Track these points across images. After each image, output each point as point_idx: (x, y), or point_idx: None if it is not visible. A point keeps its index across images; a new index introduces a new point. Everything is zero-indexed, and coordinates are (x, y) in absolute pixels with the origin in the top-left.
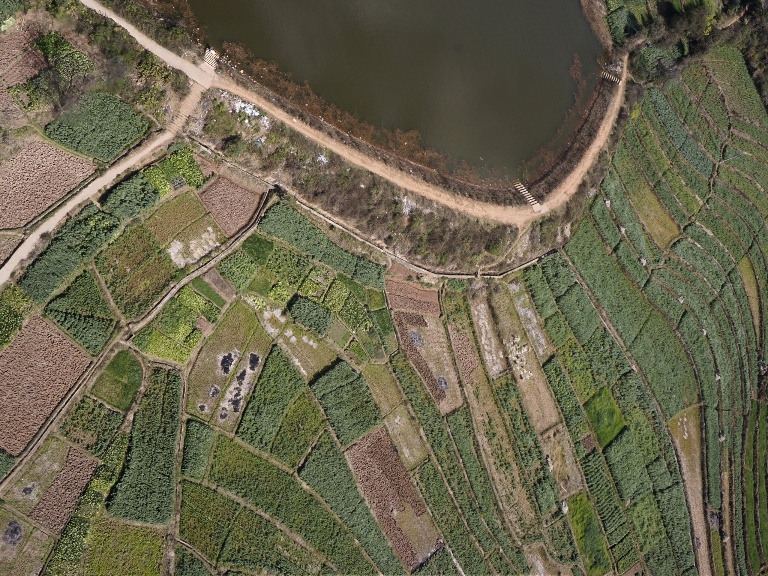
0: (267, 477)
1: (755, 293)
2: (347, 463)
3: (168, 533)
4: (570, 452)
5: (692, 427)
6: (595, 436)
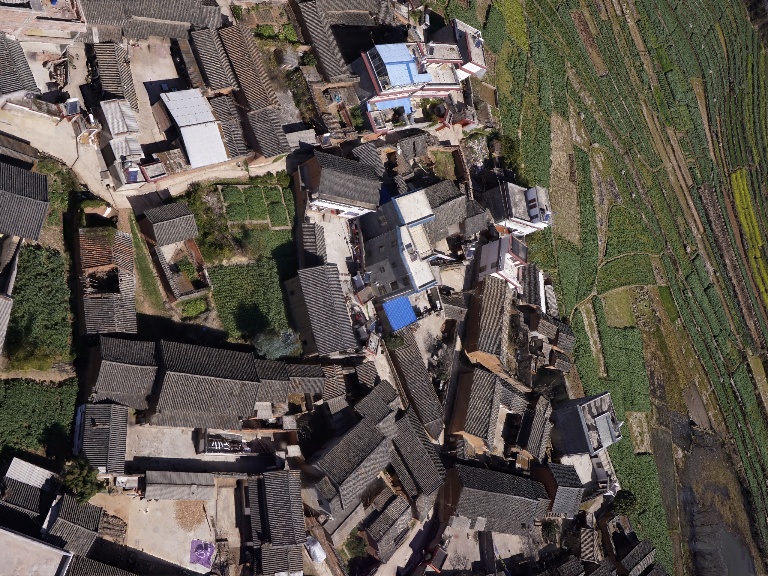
0: (547, 6)
1: (724, 43)
2: (572, 18)
3: (523, 5)
4: (651, 67)
5: (700, 89)
6: (660, 66)
